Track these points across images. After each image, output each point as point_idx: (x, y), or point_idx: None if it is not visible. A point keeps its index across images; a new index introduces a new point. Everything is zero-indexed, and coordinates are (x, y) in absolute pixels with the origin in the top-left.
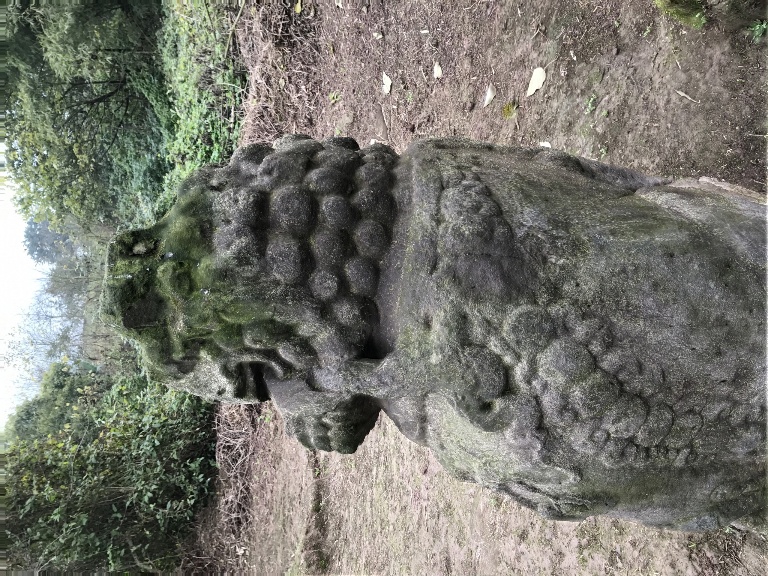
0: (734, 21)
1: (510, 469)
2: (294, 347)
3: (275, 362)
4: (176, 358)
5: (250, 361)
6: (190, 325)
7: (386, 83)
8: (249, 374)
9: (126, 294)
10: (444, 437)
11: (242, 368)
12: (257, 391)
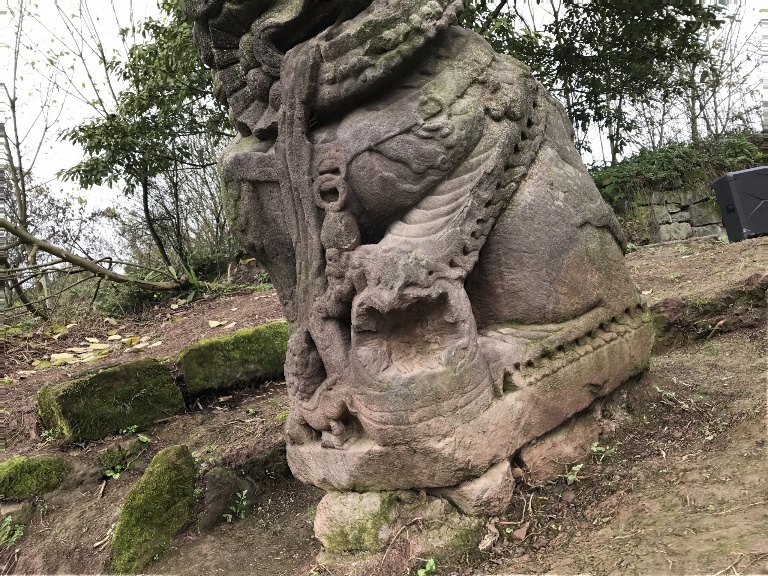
0: (217, 502)
1: None
2: None
3: None
4: None
5: None
6: None
7: None
8: None
9: None
10: None
11: None
12: None
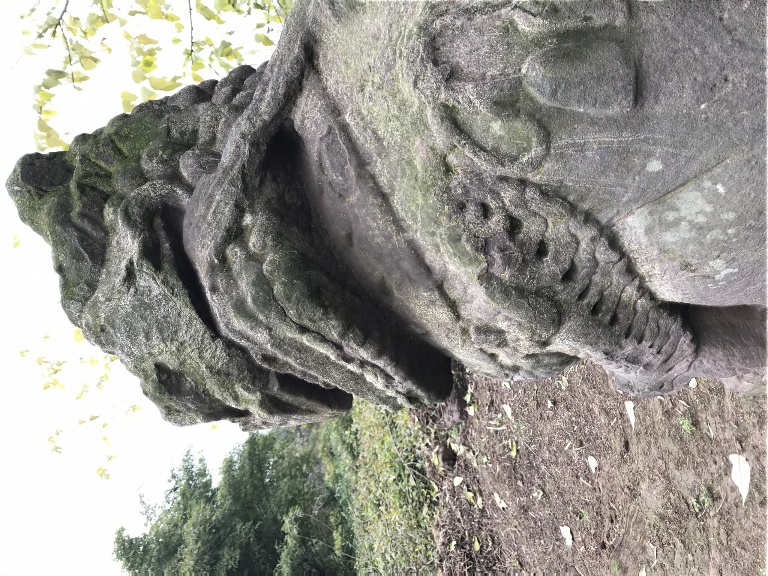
0: None
1: (417, 12)
2: (192, 151)
3: (179, 188)
4: (74, 220)
5: (164, 226)
6: (81, 153)
7: (565, 534)
8: (163, 240)
9: (30, 154)
10: (364, 109)
11: (153, 231)
12: (177, 268)
